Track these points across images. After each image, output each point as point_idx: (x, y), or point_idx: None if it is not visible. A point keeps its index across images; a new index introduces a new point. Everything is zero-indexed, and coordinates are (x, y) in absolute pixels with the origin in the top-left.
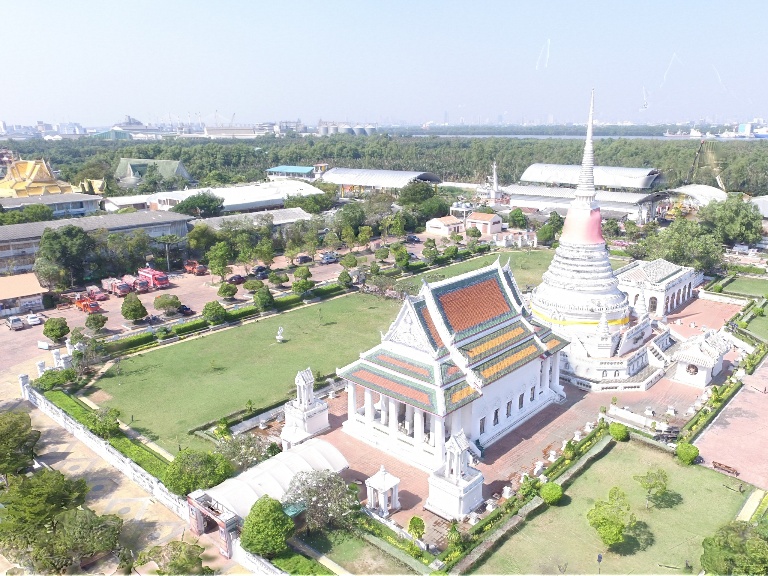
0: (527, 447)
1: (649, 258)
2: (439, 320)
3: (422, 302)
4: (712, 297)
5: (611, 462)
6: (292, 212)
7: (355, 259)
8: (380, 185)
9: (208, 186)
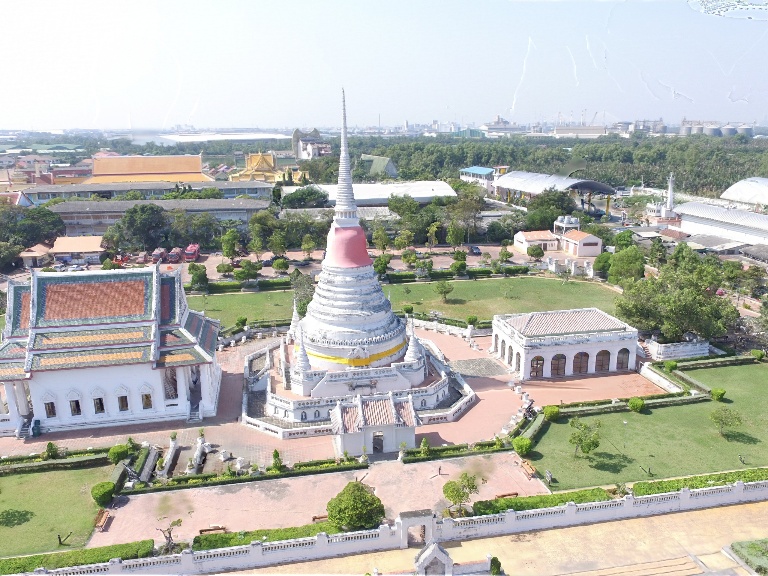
0: (76, 442)
1: None
2: (30, 305)
3: (27, 287)
4: (652, 375)
5: (67, 475)
6: (375, 211)
7: None
8: (535, 192)
9: (380, 182)
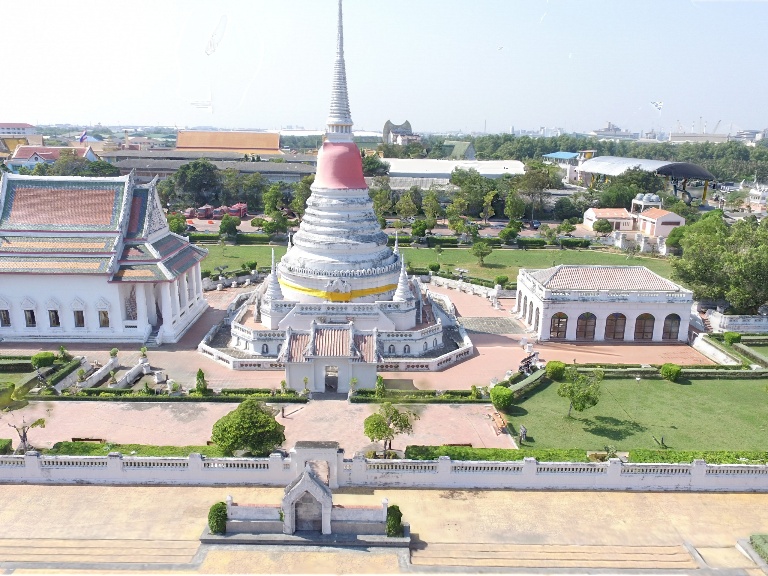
0: (21, 353)
1: None
2: None
3: None
4: (706, 348)
5: None
6: (434, 182)
7: (384, 221)
8: None
9: None
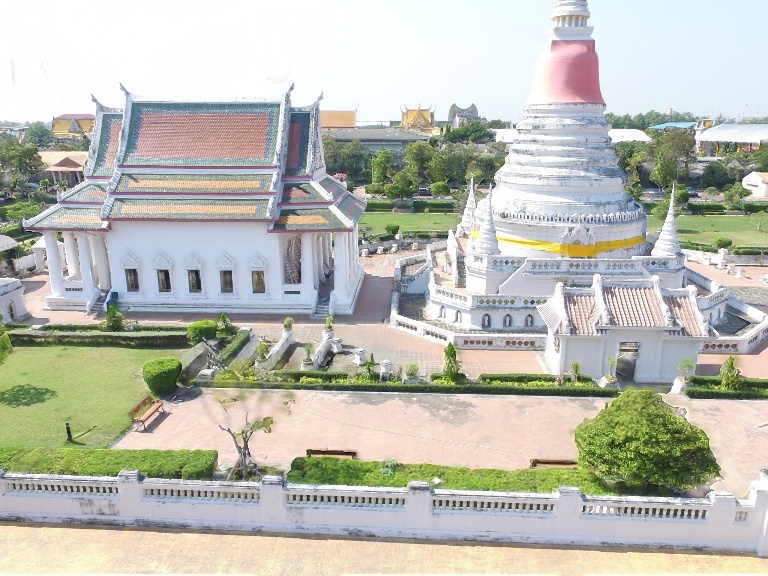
0: (157, 324)
1: None
2: None
3: (120, 115)
4: None
5: (125, 354)
6: None
7: None
8: (759, 141)
9: None
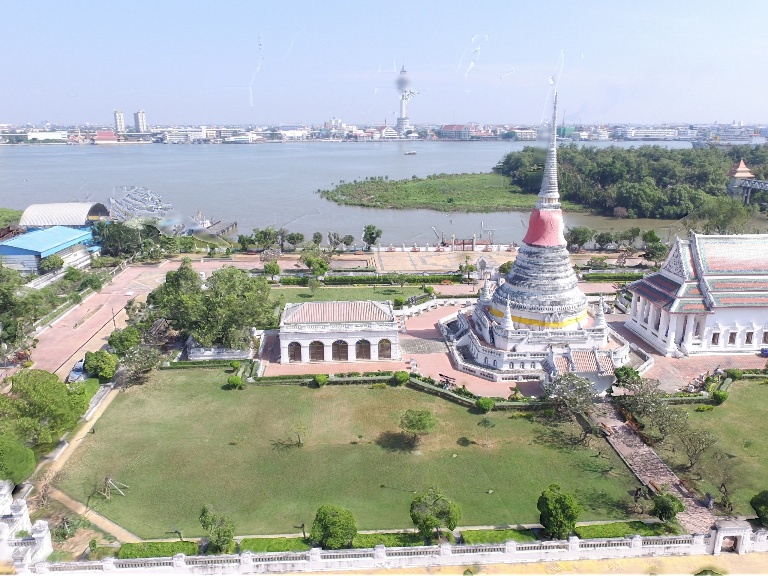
0: None
1: (238, 330)
2: None
3: None
4: None
5: None
6: None
7: None
8: None
9: None
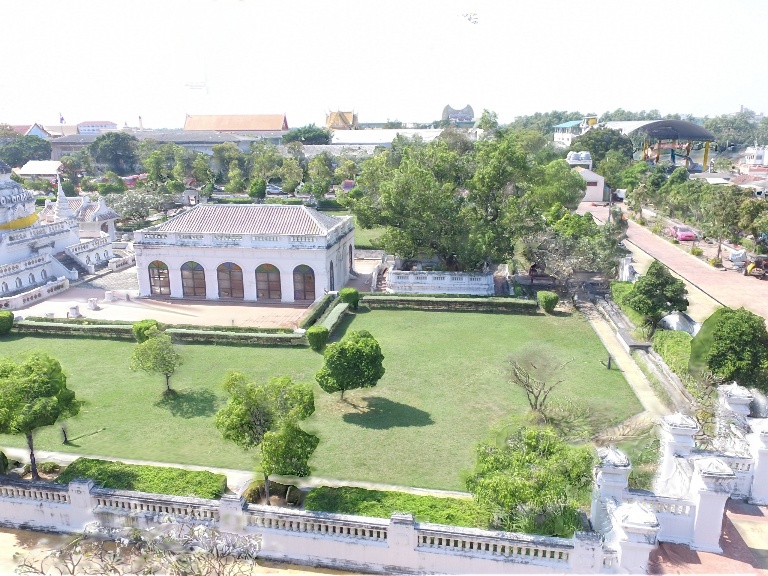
0: None
1: None
2: None
3: None
4: None
5: None
6: None
7: (241, 184)
8: None
9: None
